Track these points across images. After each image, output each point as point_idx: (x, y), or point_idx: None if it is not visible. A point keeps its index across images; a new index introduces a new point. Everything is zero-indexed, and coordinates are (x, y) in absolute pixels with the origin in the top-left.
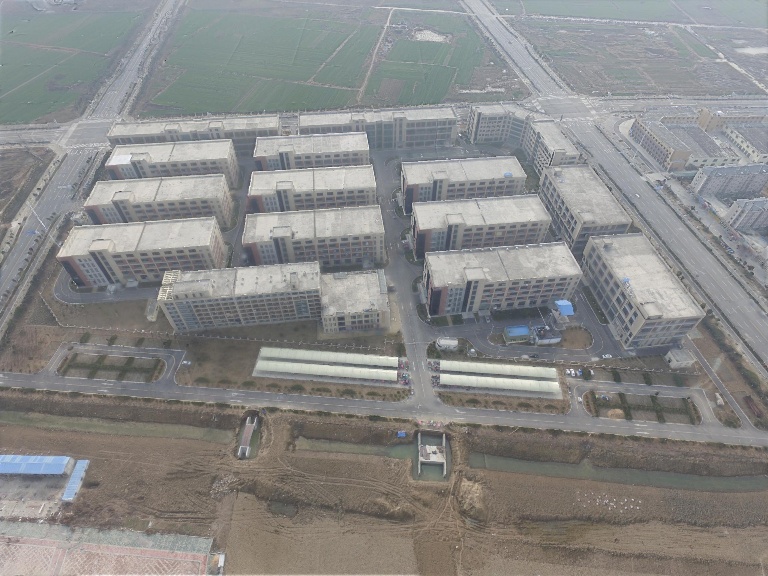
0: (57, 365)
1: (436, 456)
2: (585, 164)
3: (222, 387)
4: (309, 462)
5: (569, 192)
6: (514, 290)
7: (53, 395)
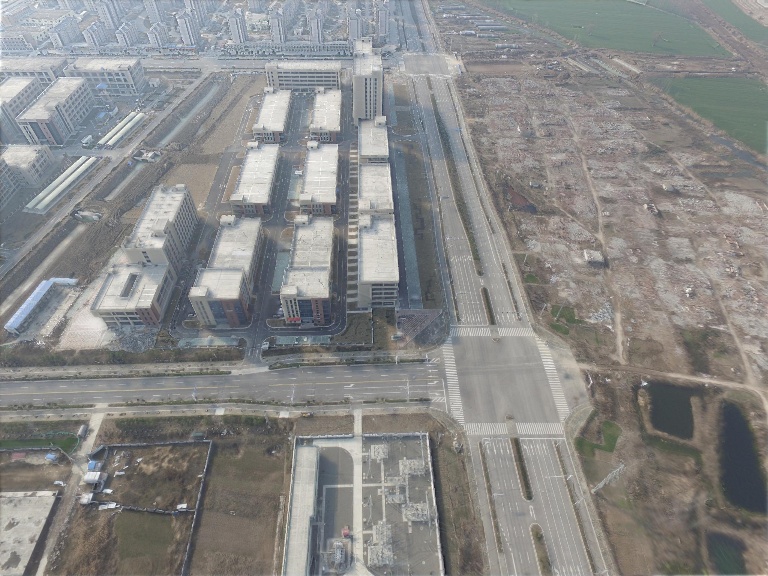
0: None
1: (149, 154)
2: (0, 57)
3: (41, 227)
4: (122, 192)
5: (19, 68)
6: (74, 104)
7: None
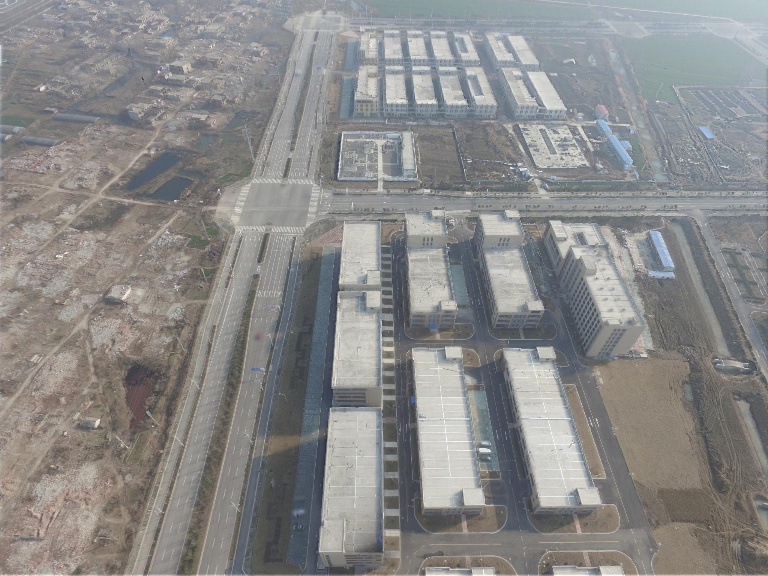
0: (728, 247)
1: None
2: None
3: (765, 343)
4: (732, 409)
5: None
6: None
7: (706, 250)
